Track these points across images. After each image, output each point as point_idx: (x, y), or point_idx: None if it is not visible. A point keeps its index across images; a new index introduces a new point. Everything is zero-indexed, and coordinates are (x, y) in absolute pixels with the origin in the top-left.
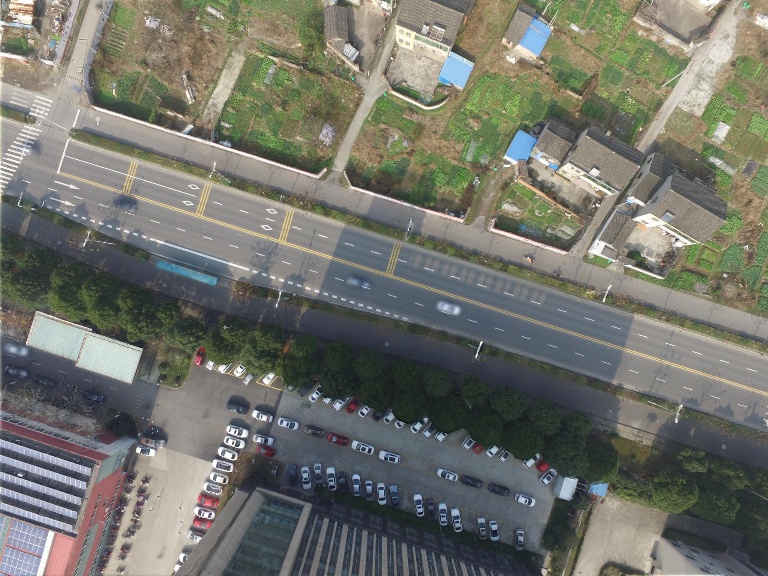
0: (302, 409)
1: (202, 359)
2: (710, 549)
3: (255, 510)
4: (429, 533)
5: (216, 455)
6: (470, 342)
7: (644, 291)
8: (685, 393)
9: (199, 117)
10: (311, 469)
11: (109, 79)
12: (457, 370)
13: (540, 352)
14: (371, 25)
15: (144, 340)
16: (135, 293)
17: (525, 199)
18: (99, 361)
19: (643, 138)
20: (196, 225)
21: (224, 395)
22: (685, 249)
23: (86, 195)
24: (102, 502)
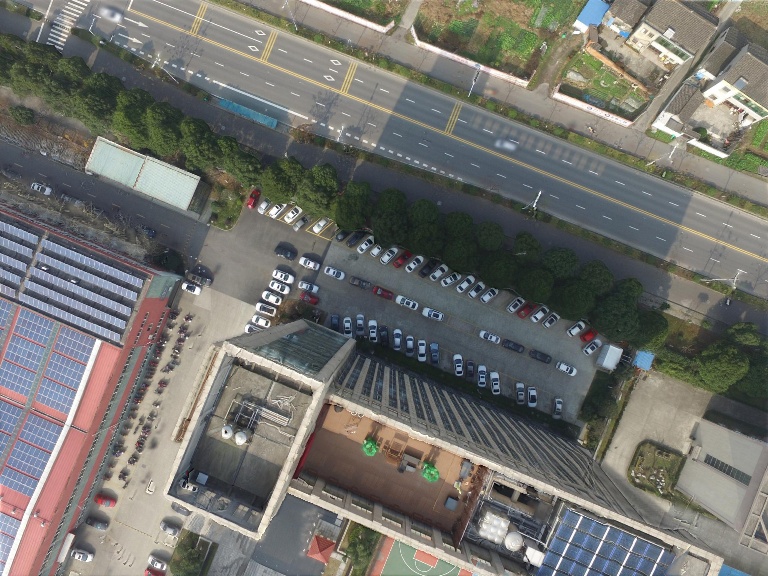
0: (349, 261)
1: (255, 202)
2: (752, 435)
3: (303, 328)
4: (466, 394)
5: (260, 299)
6: (524, 206)
7: (705, 170)
8: (739, 276)
9: None
10: (353, 321)
11: None
12: (508, 234)
13: (594, 223)
14: None
15: (202, 169)
16: (198, 121)
17: (591, 69)
18: (156, 186)
19: (718, 15)
20: (259, 70)
21: (273, 241)
22: (751, 131)
23: (154, 33)
24: (147, 325)
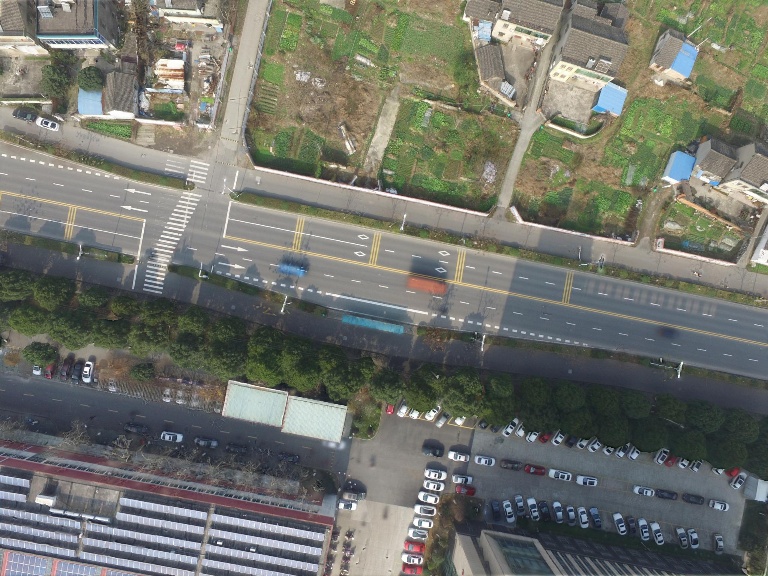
0: (495, 445)
1: (394, 408)
2: None
3: (501, 555)
4: (632, 549)
5: (416, 500)
6: (652, 360)
7: None
8: None
9: (360, 167)
10: (511, 502)
11: (265, 137)
12: (640, 389)
13: (716, 362)
14: (520, 60)
15: (347, 397)
16: (334, 352)
17: (685, 216)
18: (305, 424)
19: None
20: (370, 275)
21: (417, 440)
22: None
23: (255, 256)
24: None
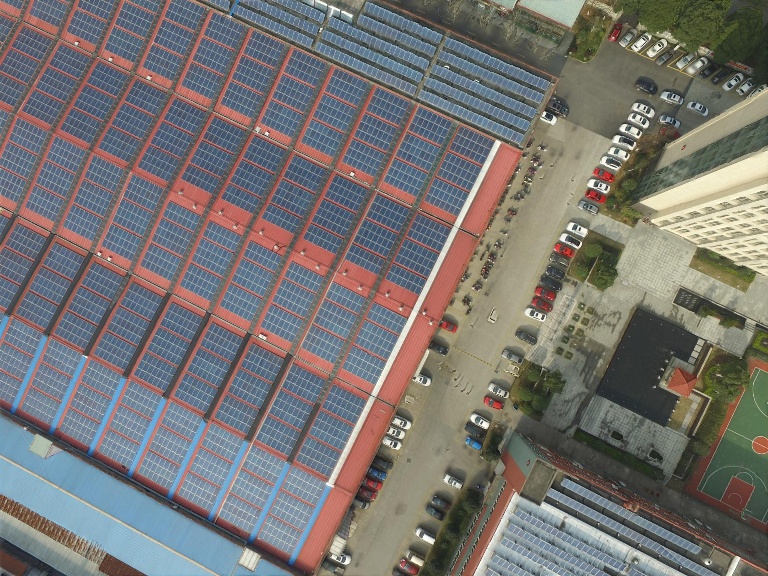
0: (712, 98)
1: (619, 33)
2: None
3: None
4: None
5: (616, 133)
6: None
7: None
8: None
9: None
10: None
11: None
12: None
13: None
14: None
15: None
16: None
17: None
18: (542, 2)
19: None
20: None
21: (632, 75)
22: None
23: None
24: None
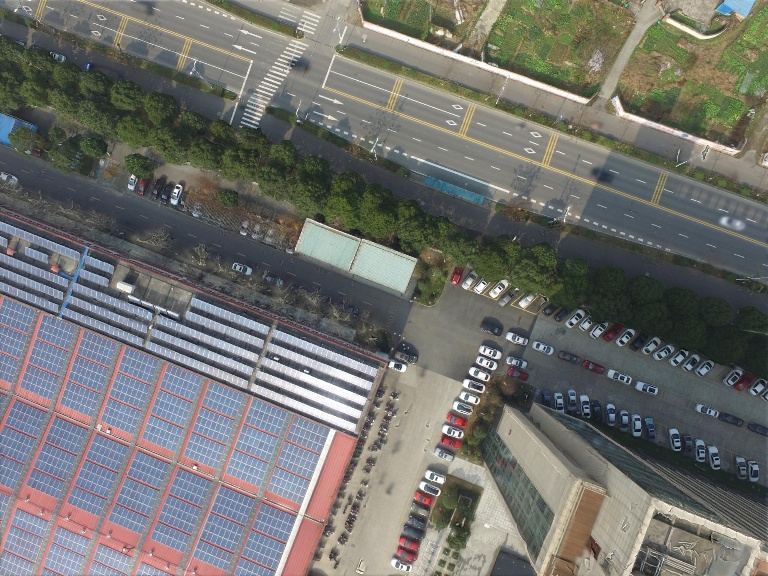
0: (556, 335)
1: (460, 278)
2: None
3: None
4: (684, 469)
5: (466, 375)
6: (738, 276)
7: None
8: None
9: (466, 38)
10: (563, 396)
11: None
12: None
13: None
14: None
15: (419, 251)
16: (413, 203)
17: None
18: (373, 269)
19: None
20: (458, 145)
21: (477, 316)
22: None
23: (349, 110)
24: None
